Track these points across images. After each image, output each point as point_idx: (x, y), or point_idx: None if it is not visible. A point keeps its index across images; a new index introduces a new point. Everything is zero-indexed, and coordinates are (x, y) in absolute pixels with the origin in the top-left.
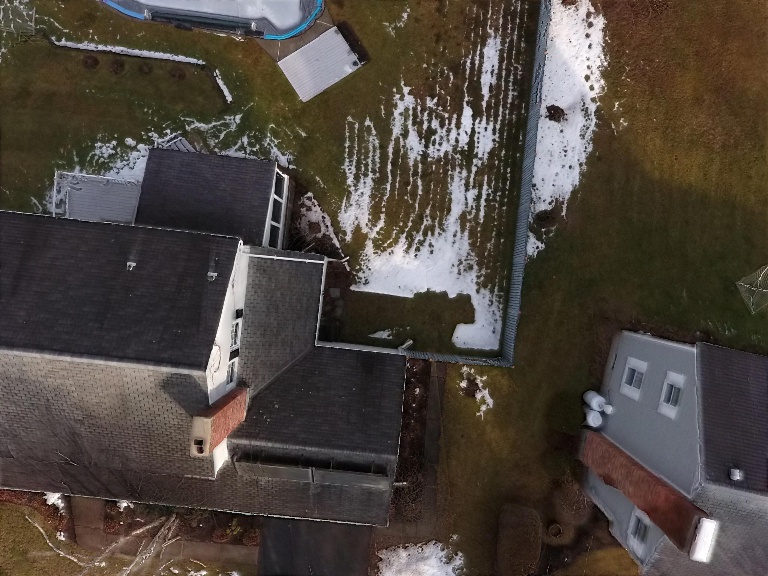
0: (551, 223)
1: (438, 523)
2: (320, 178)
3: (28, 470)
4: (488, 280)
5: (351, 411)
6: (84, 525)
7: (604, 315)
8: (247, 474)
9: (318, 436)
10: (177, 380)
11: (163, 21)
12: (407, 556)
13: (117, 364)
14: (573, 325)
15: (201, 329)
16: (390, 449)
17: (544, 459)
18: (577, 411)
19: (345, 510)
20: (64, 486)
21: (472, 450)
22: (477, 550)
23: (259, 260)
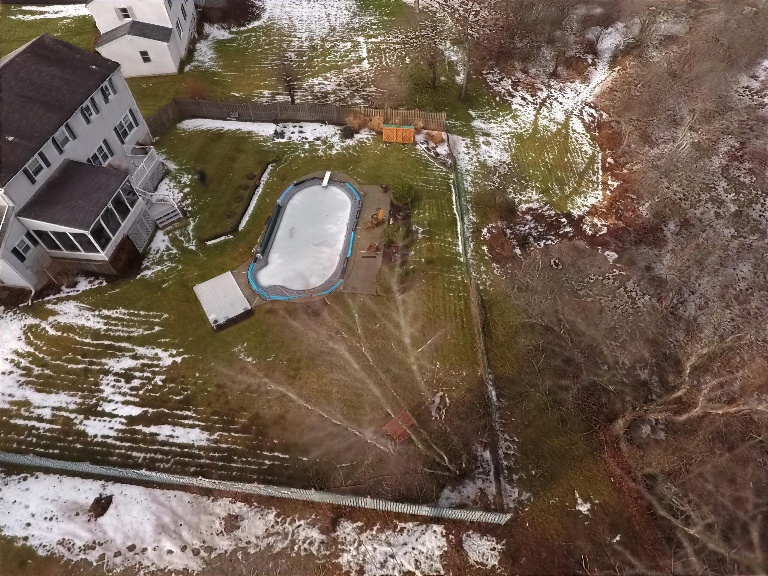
0: None
1: None
2: (117, 292)
3: None
4: None
5: None
6: None
7: None
8: None
9: None
10: None
11: (274, 210)
12: None
13: None
14: None
15: None
16: None
17: None
18: None
19: None
20: None
21: None
22: None
23: (4, 212)
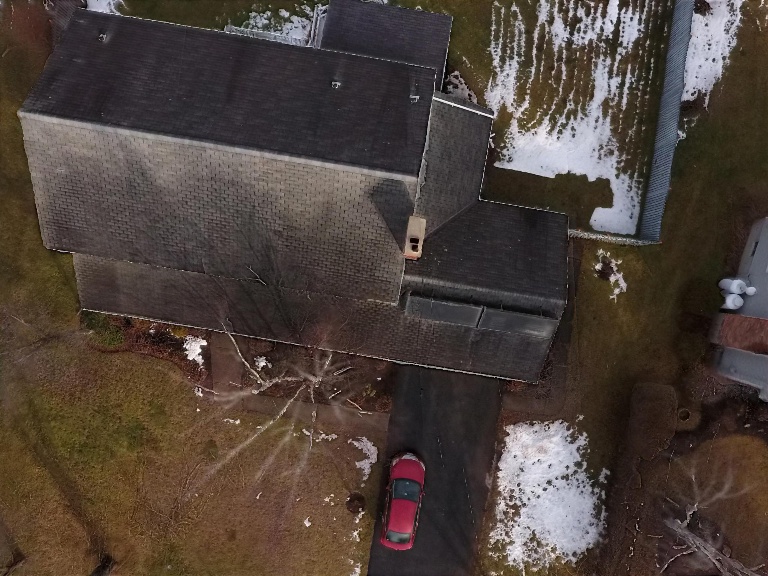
0: (693, 113)
1: (566, 402)
2: (466, 58)
3: (197, 303)
4: (628, 166)
5: (518, 259)
6: (222, 382)
7: (745, 204)
8: (413, 315)
9: (488, 279)
10: (387, 187)
11: None
12: (534, 433)
13: (334, 166)
14: (711, 214)
15: (409, 143)
16: (559, 295)
17: (678, 342)
18: (717, 294)
19: (500, 362)
20: (228, 323)
21: (604, 332)
22: (602, 432)
23: (439, 104)
